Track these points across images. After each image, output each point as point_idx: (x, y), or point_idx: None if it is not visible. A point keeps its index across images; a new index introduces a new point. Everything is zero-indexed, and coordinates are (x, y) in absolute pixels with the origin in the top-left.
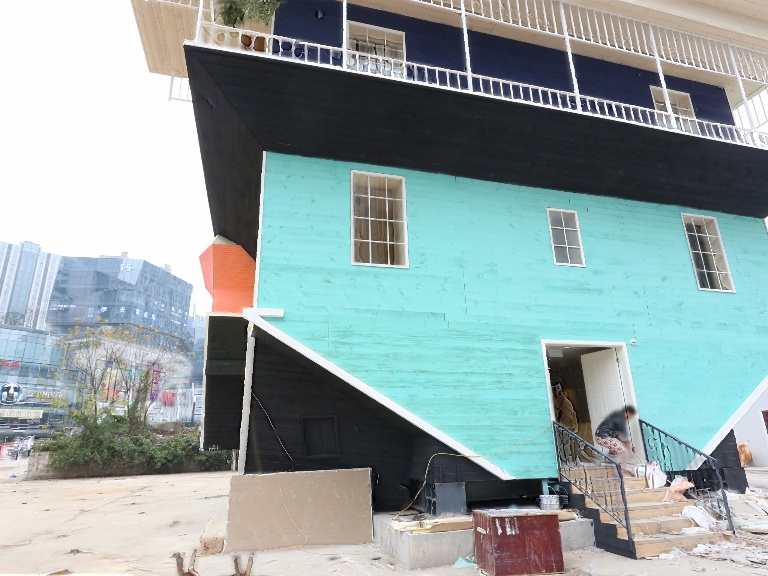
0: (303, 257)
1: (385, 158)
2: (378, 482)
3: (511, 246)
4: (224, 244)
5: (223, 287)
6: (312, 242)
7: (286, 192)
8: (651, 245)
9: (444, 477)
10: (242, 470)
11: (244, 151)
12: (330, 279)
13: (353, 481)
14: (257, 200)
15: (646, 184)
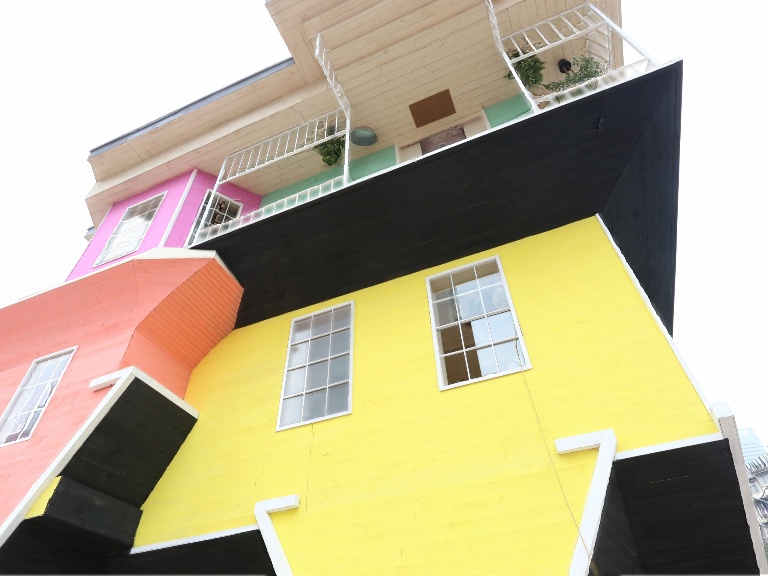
0: None
1: None
2: None
3: None
4: (226, 271)
5: (152, 336)
6: None
7: None
8: None
9: None
10: None
11: (554, 195)
12: None
13: None
14: (452, 254)
15: None
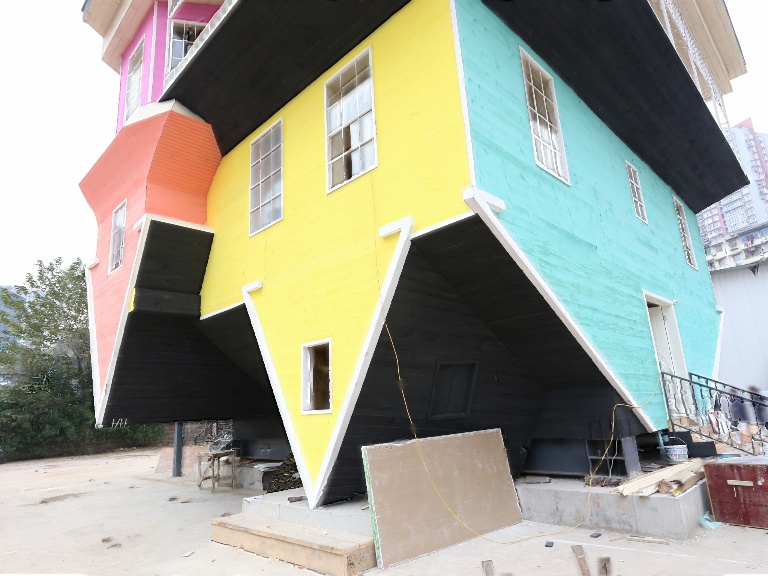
0: (501, 137)
1: (546, 45)
2: (506, 445)
3: (616, 188)
4: (187, 116)
5: (162, 182)
6: (505, 120)
7: (475, 40)
8: (667, 217)
9: (624, 431)
10: (340, 441)
11: None
12: (524, 176)
13: (490, 446)
14: (337, 52)
15: (670, 160)
